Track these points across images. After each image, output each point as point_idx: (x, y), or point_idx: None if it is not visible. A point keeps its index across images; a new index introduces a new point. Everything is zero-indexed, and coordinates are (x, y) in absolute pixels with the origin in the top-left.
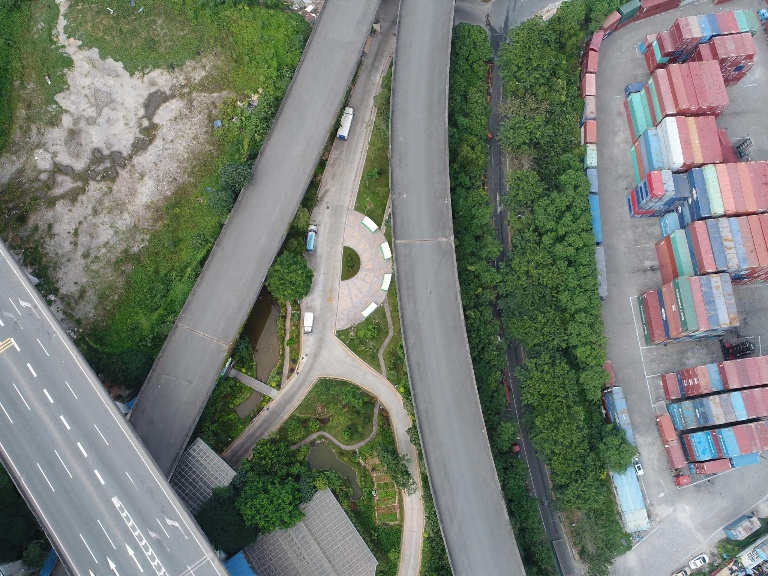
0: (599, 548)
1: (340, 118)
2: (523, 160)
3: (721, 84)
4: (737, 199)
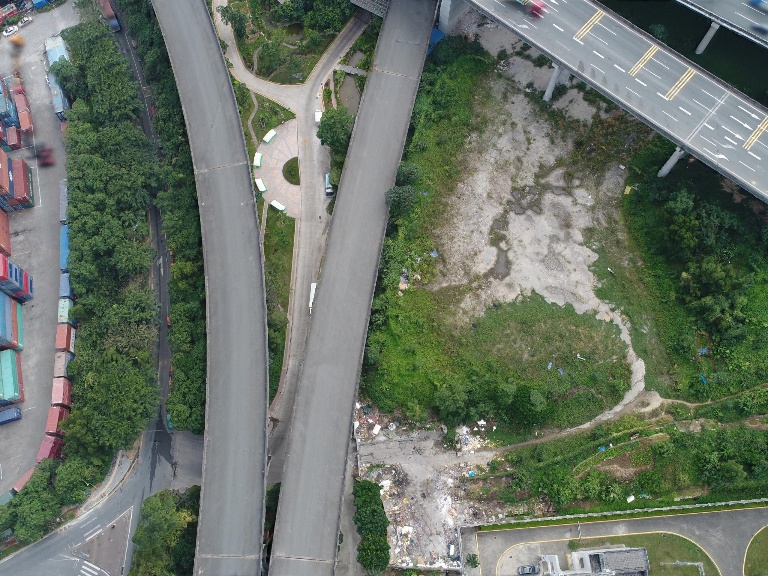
0: (84, 8)
1: None
2: None
3: None
4: None
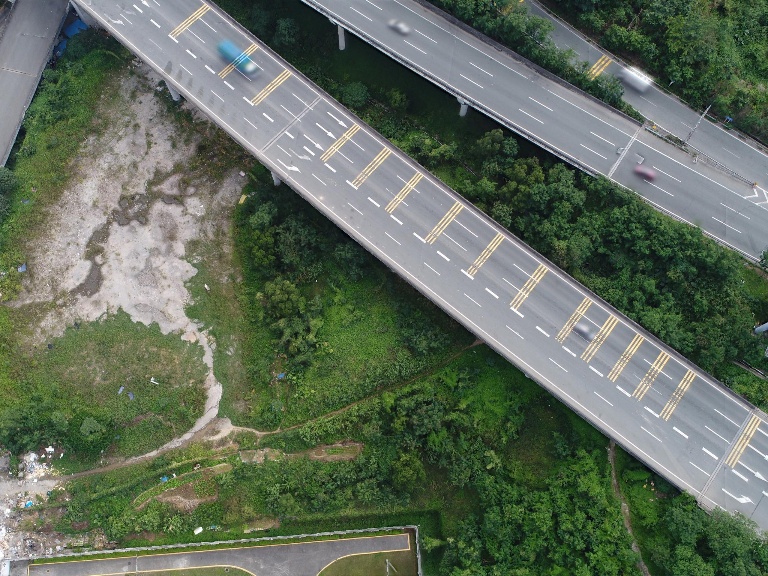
0: None
1: None
2: None
3: None
4: None
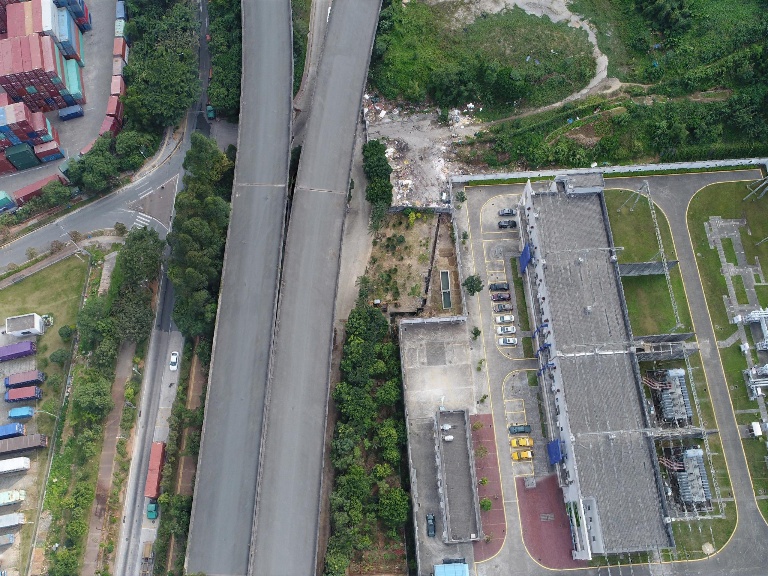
0: None
1: None
2: None
3: None
4: None
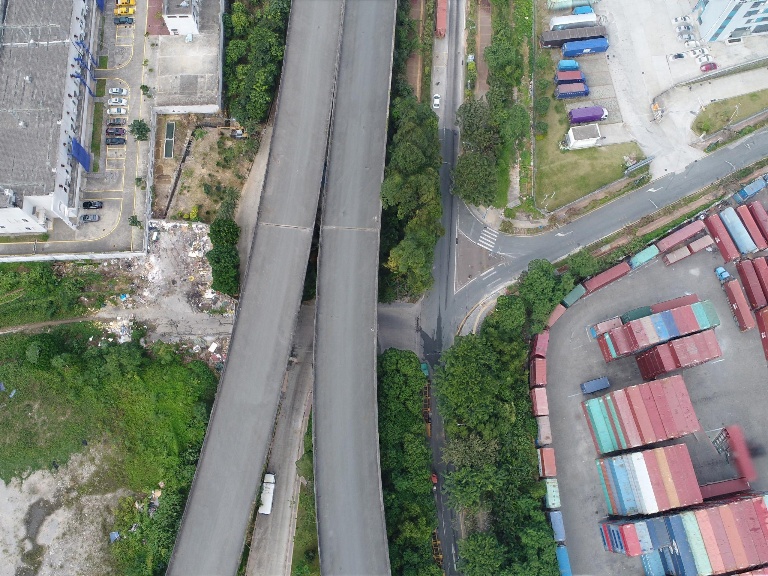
0: None
1: (259, 496)
2: (476, 515)
3: (688, 405)
4: (725, 555)
